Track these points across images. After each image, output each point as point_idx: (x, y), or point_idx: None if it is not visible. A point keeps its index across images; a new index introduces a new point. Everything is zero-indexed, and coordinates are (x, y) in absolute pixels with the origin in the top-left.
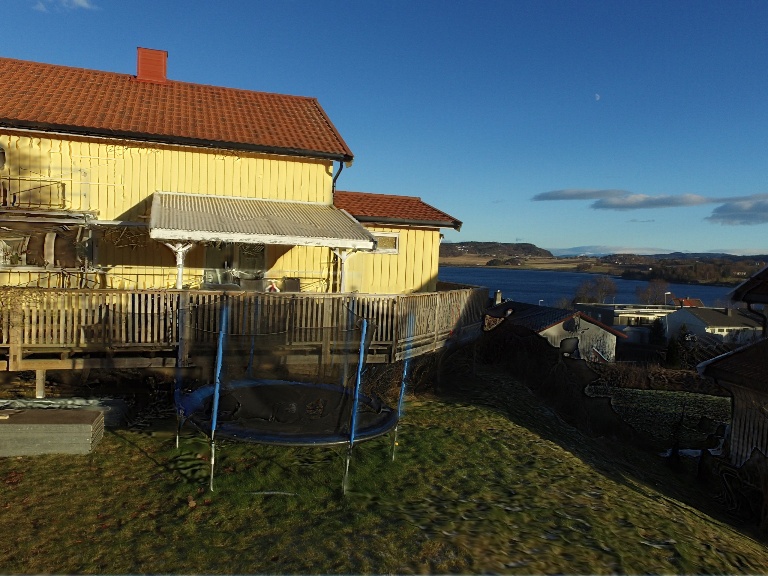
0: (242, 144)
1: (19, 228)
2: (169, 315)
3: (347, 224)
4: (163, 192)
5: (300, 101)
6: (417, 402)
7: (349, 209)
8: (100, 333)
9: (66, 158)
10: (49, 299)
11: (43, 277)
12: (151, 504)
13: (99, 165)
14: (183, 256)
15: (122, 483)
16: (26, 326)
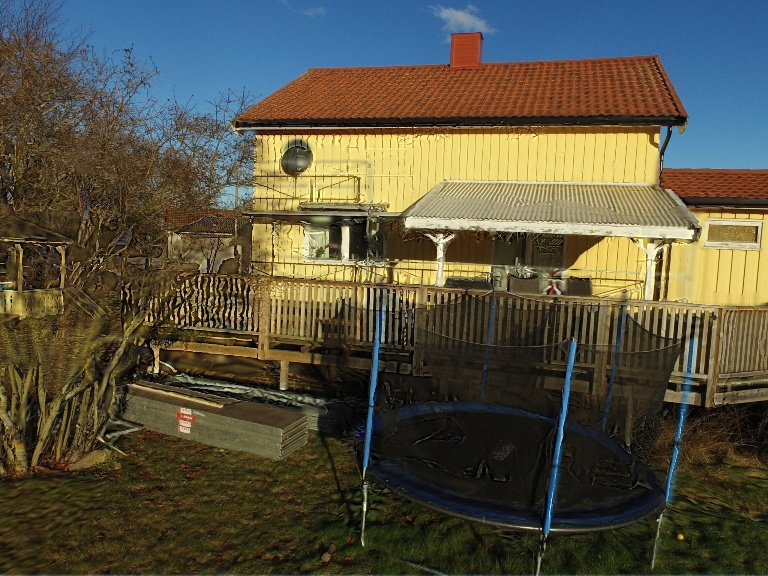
0: (537, 118)
1: (316, 222)
2: (404, 314)
3: (664, 207)
4: (451, 181)
5: (635, 62)
6: (758, 470)
7: (684, 190)
8: (336, 328)
9: (362, 152)
10: (293, 290)
11: (339, 270)
12: (289, 542)
13: (391, 156)
14: (444, 248)
15: (282, 505)
16: (273, 316)
